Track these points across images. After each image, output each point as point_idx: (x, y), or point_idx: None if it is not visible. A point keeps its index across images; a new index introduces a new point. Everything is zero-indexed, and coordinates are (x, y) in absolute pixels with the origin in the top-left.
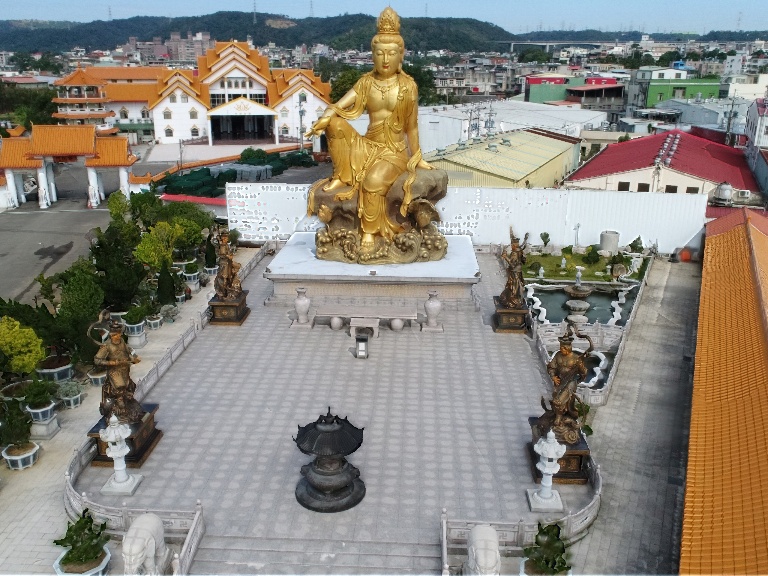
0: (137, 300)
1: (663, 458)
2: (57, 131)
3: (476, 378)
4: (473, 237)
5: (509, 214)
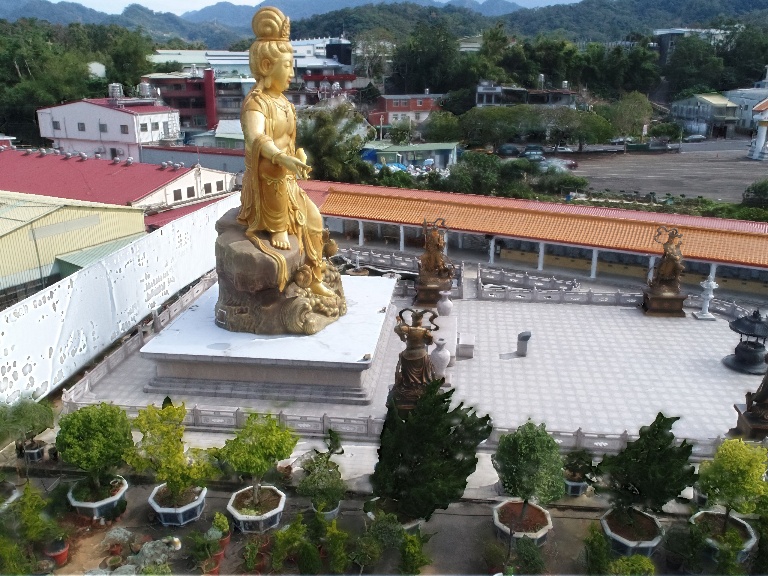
0: (333, 511)
1: (634, 290)
2: None
3: (549, 320)
4: (176, 282)
5: (192, 244)
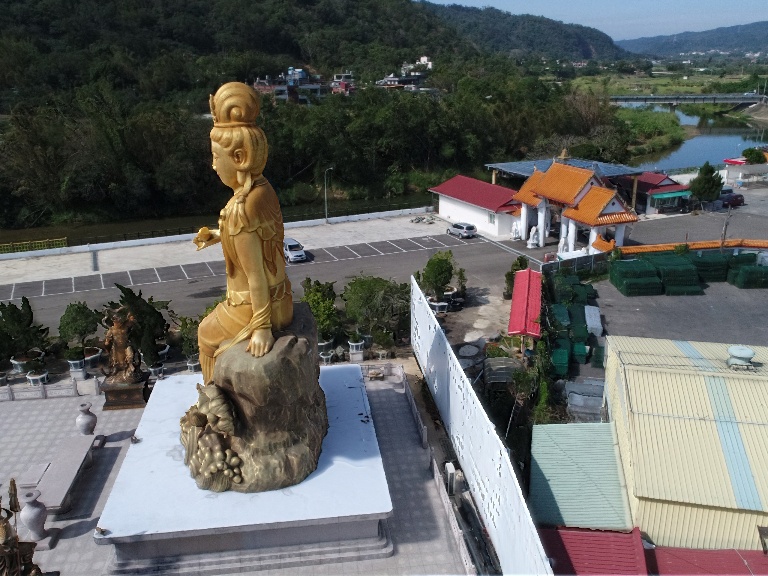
0: None
1: None
2: (566, 172)
3: None
4: None
5: (515, 540)
